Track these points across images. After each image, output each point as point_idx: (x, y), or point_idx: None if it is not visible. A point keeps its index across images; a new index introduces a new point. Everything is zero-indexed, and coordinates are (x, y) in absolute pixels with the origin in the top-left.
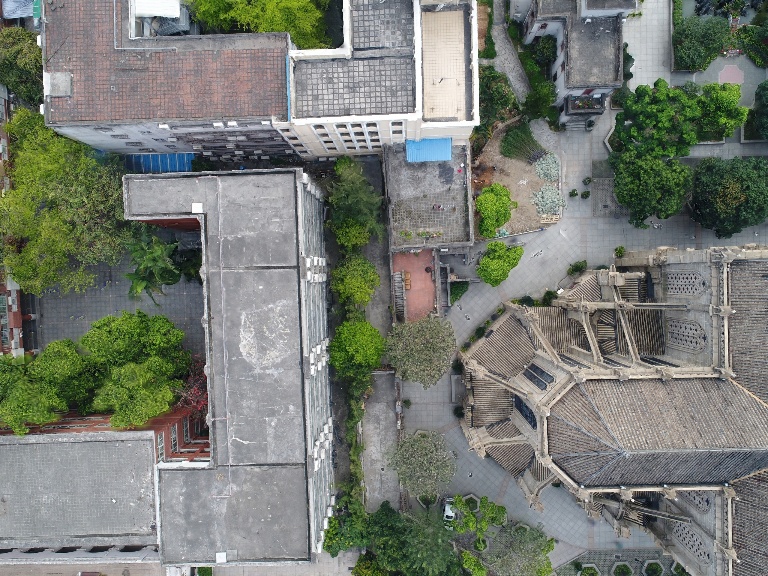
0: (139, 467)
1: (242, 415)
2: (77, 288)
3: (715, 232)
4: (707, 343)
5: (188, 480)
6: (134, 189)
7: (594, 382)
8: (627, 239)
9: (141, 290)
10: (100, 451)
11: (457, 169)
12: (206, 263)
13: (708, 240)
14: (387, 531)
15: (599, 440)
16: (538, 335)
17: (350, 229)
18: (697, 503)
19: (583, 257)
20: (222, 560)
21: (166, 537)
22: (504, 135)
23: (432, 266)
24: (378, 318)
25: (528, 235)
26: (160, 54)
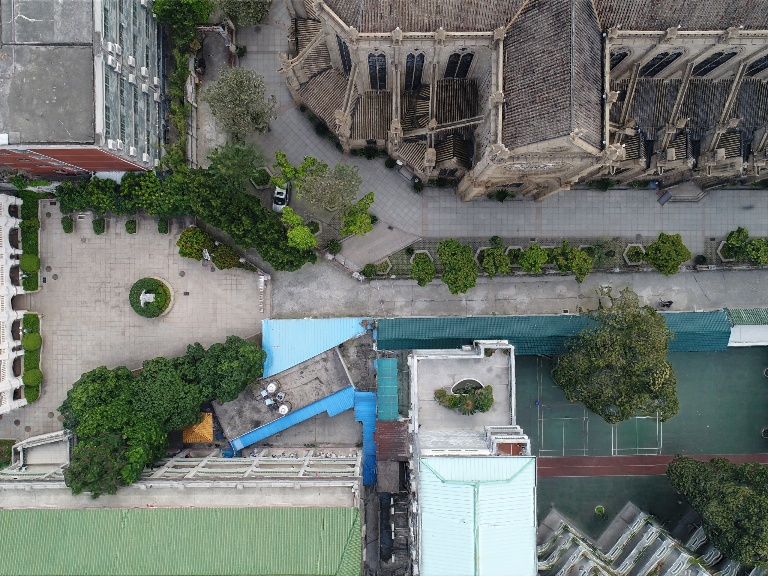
0: None
1: None
2: None
3: None
4: None
5: None
6: None
7: None
8: None
9: None
10: None
11: None
12: None
13: None
14: None
15: None
16: None
17: None
18: None
19: None
20: (3, 142)
21: None
22: None
23: None
24: None
25: None
26: None
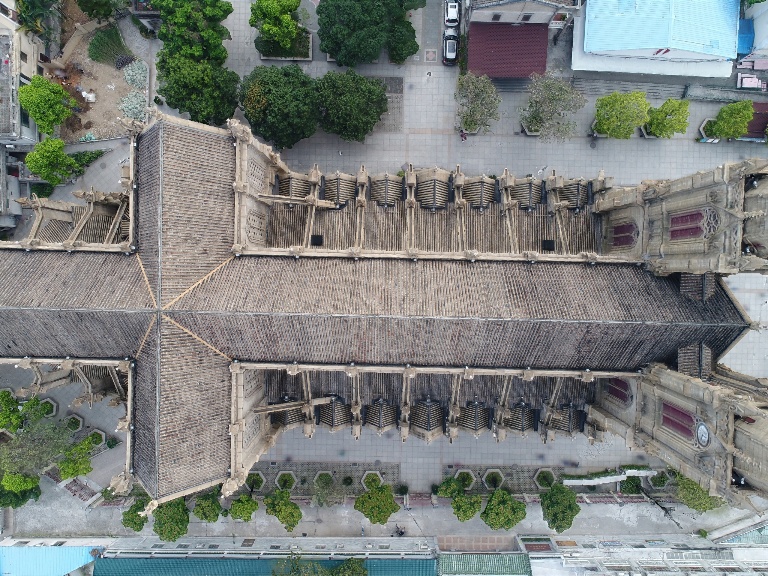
0: None
1: None
2: None
3: (272, 142)
4: None
5: None
6: None
7: (6, 252)
8: None
9: None
10: None
11: (5, 60)
12: None
13: (293, 157)
14: None
15: None
16: None
17: None
18: None
19: None
20: None
21: None
22: (93, 38)
23: None
24: None
25: (116, 141)
26: None
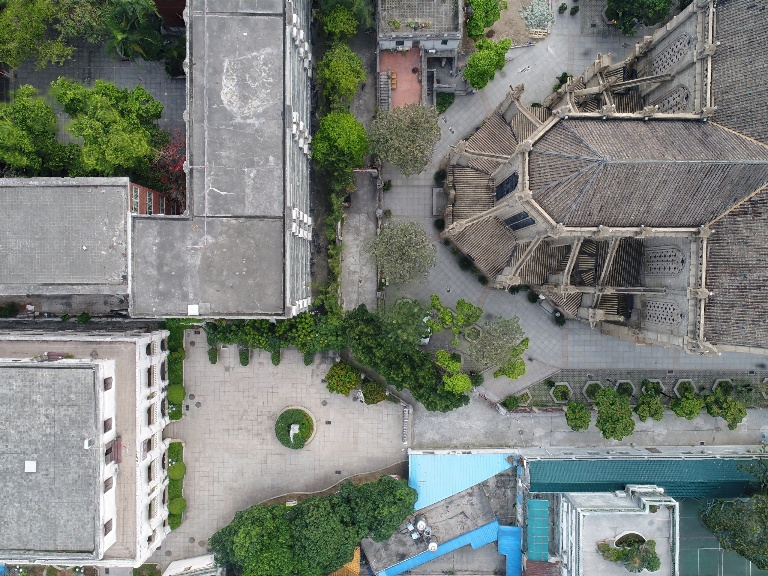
0: (112, 214)
1: (221, 165)
2: (54, 56)
3: None
4: (690, 98)
5: (162, 230)
6: None
7: (577, 121)
8: (614, 59)
9: (121, 38)
10: (72, 197)
11: None
12: (190, 7)
13: None
14: (363, 323)
15: (580, 157)
16: (523, 110)
17: (338, 13)
18: (672, 271)
19: (569, 75)
20: (194, 312)
21: (137, 288)
22: None
23: (419, 67)
24: None
25: (516, 50)
26: None
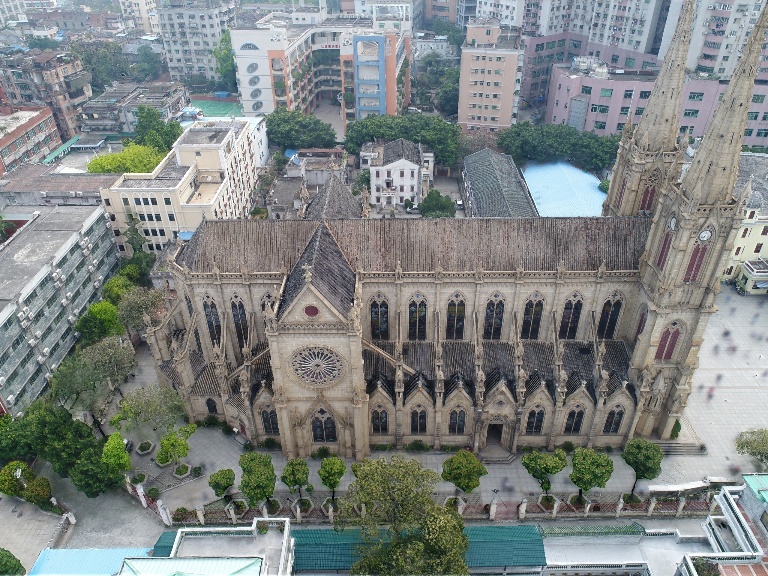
0: None
1: None
2: None
3: None
4: None
5: None
6: (8, 208)
7: None
8: None
9: None
10: None
11: None
12: (24, 229)
13: None
14: None
15: None
16: None
17: None
18: None
19: None
20: None
21: None
22: None
23: None
24: (131, 336)
25: None
26: (61, 178)
